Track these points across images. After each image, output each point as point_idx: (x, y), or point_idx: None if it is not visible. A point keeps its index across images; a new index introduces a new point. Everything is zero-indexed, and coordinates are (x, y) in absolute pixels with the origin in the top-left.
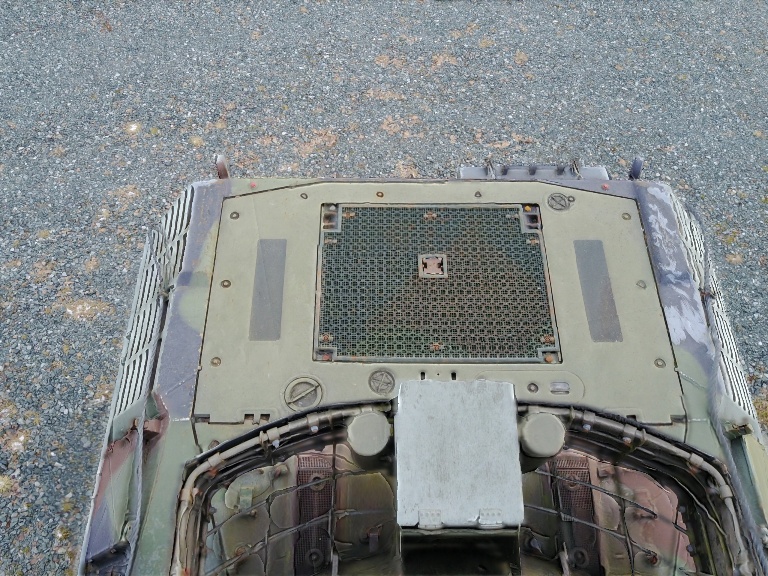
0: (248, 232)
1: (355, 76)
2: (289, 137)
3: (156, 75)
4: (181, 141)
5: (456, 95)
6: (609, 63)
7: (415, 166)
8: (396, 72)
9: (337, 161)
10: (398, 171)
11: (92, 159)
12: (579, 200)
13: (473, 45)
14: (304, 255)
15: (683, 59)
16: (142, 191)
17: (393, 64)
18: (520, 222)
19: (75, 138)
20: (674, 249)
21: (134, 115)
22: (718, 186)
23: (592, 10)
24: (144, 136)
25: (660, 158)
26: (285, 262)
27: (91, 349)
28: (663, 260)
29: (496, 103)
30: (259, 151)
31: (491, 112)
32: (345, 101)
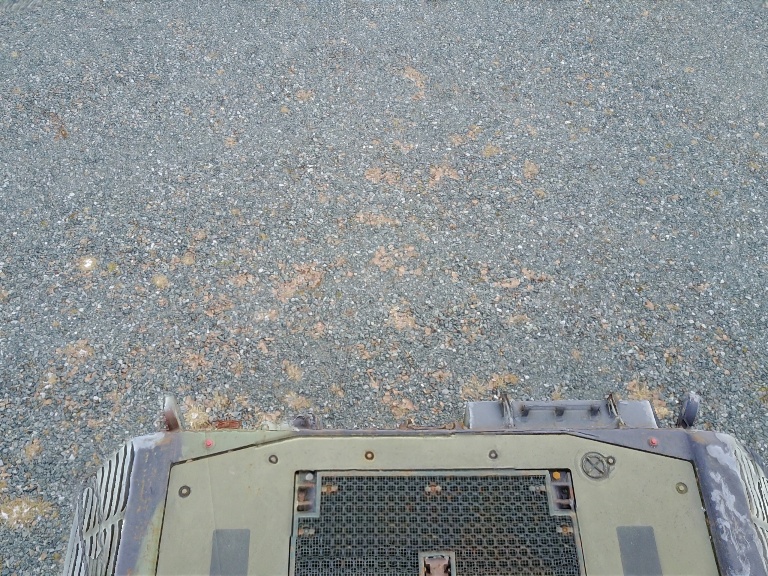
0: (201, 518)
1: (342, 195)
2: (267, 275)
3: (116, 195)
4: (142, 281)
5: (458, 218)
6: (630, 176)
7: (412, 313)
8: (389, 189)
9: (322, 307)
10: (392, 320)
11: (39, 305)
12: (620, 461)
13: (476, 154)
14: (272, 554)
15: (713, 170)
16: (95, 348)
17: (385, 179)
18: (547, 497)
19: (20, 277)
20: (746, 545)
21: (89, 247)
22: (761, 336)
23: (609, 108)
24: (100, 274)
25: (693, 299)
26: (247, 565)
27: (28, 567)
28: (733, 562)
29: (503, 229)
30: (232, 294)
31: (498, 241)
32: (331, 227)
